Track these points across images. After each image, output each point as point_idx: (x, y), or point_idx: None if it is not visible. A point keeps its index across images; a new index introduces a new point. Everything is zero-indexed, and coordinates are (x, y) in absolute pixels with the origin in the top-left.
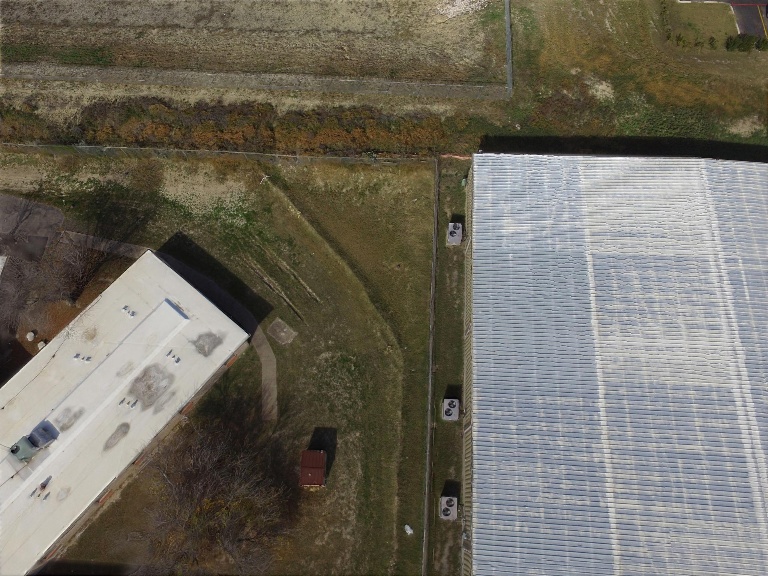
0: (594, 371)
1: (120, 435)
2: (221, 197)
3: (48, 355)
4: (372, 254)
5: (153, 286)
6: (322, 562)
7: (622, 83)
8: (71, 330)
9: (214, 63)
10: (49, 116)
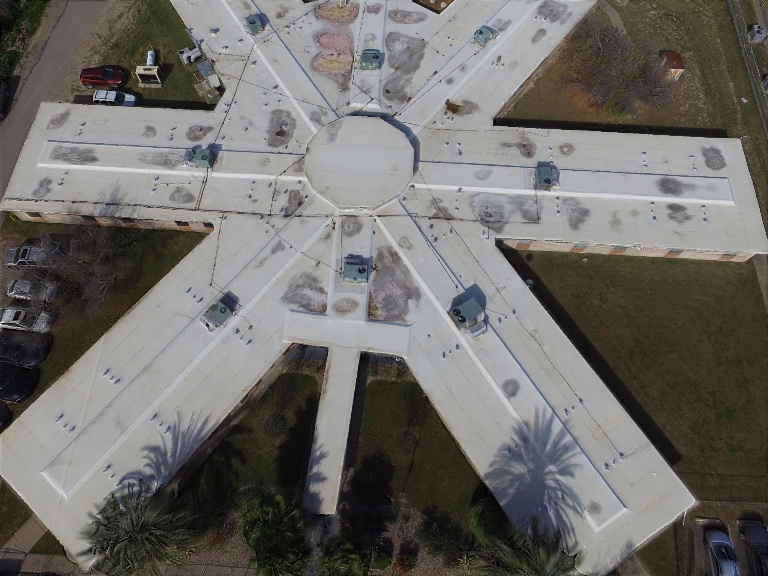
0: None
1: (541, 35)
2: None
3: None
4: None
5: None
6: (689, 118)
7: None
8: None
9: None
10: None
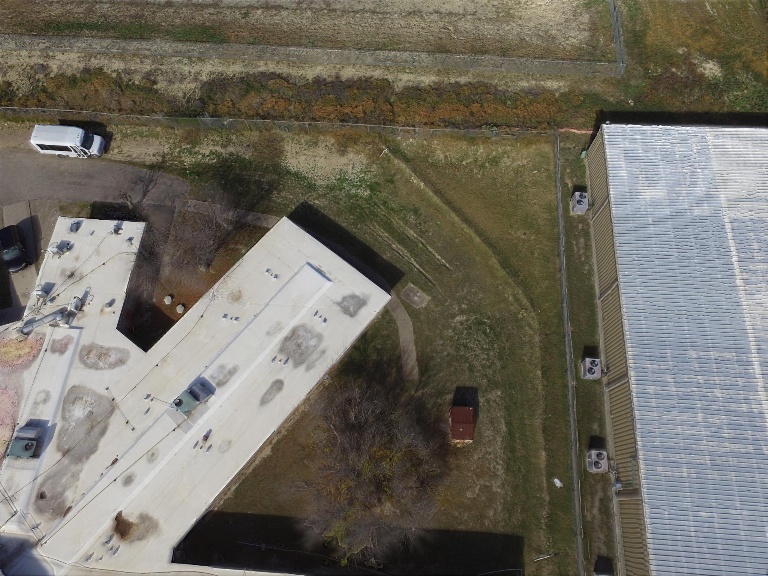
0: (744, 328)
1: (275, 391)
2: (343, 169)
3: (196, 315)
4: (497, 223)
5: (293, 250)
6: (475, 514)
7: (729, 62)
8: (216, 292)
9: (326, 41)
10: (168, 90)
